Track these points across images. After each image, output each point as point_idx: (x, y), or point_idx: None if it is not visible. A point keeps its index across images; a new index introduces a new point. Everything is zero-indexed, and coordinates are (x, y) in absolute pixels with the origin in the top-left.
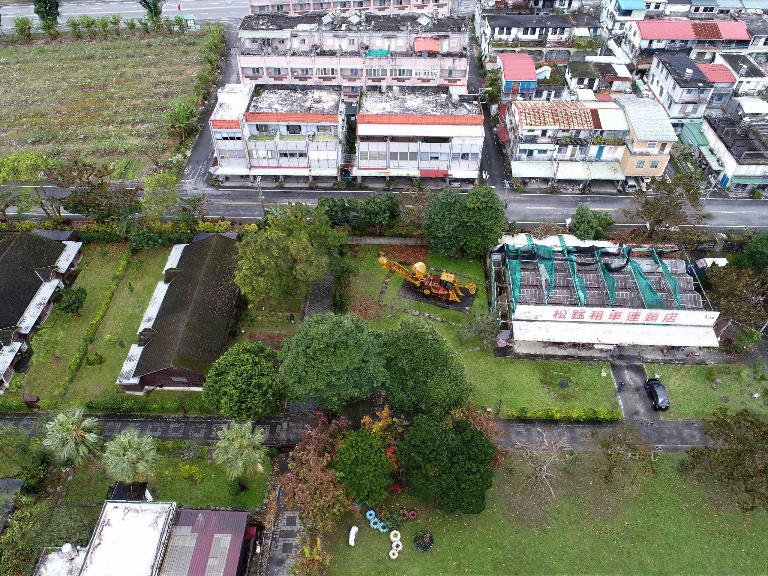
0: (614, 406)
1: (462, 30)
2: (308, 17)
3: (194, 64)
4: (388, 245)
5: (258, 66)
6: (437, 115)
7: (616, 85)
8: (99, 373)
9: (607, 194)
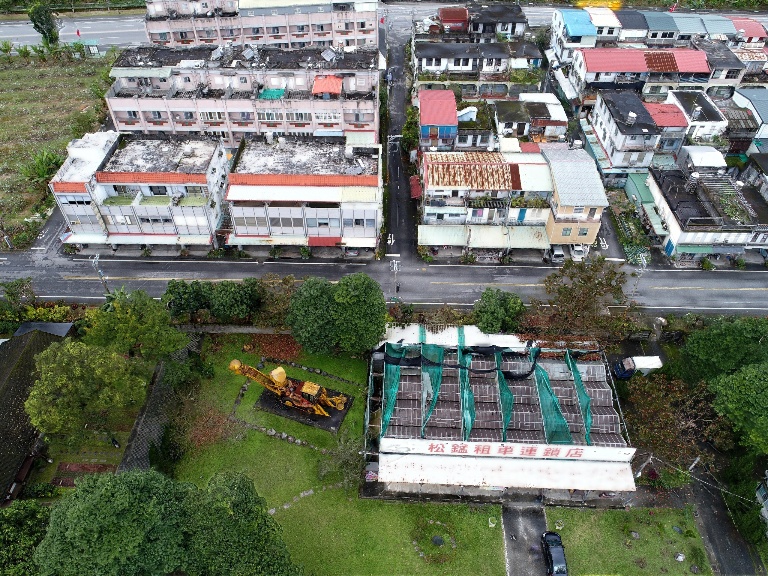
0: (498, 573)
1: (370, 67)
2: (197, 51)
3: (87, 98)
4: (258, 335)
5: (132, 109)
6: (323, 175)
7: (549, 130)
8: None
9: (530, 264)
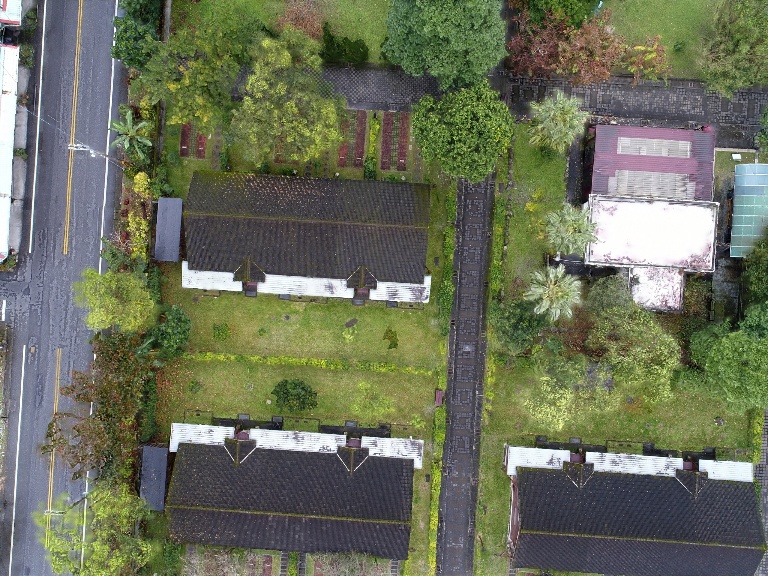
0: None
1: None
2: None
3: None
4: None
5: None
6: None
7: None
8: None
9: None
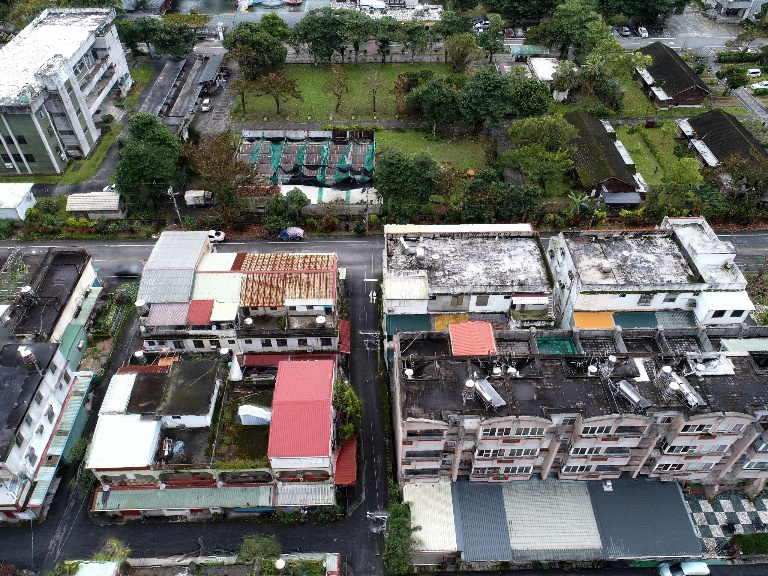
0: None
1: None
2: None
3: None
4: None
5: None
6: (442, 232)
7: None
8: (629, 139)
9: None
